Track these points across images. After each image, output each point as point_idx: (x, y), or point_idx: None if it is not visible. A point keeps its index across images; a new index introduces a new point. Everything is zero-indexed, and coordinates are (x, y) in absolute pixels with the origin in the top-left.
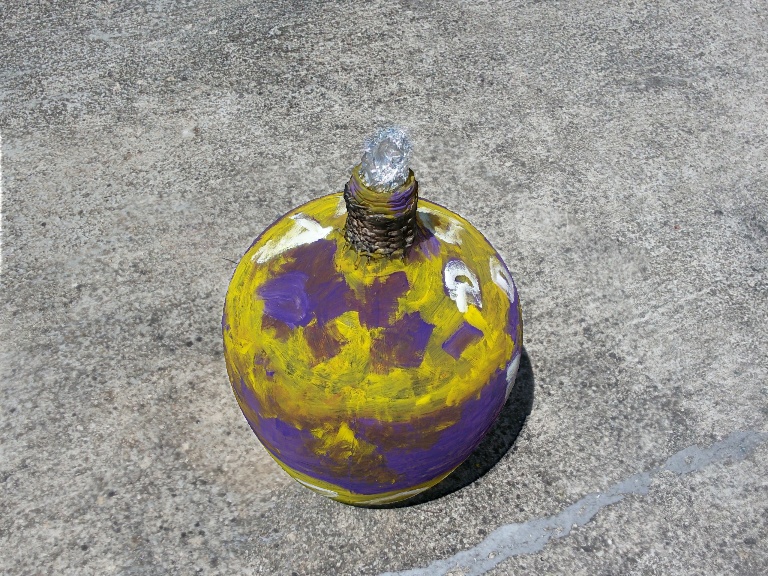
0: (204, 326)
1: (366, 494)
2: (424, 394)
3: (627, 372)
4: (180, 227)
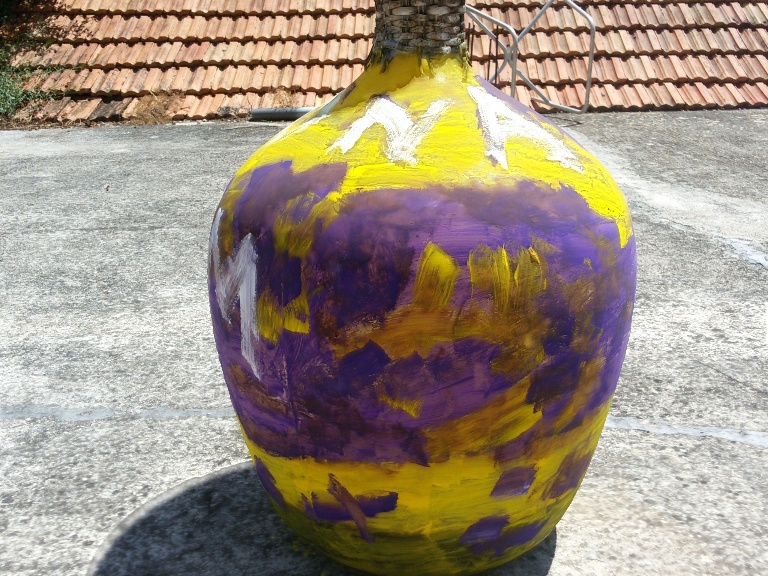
0: None
1: None
2: None
3: (21, 482)
4: None
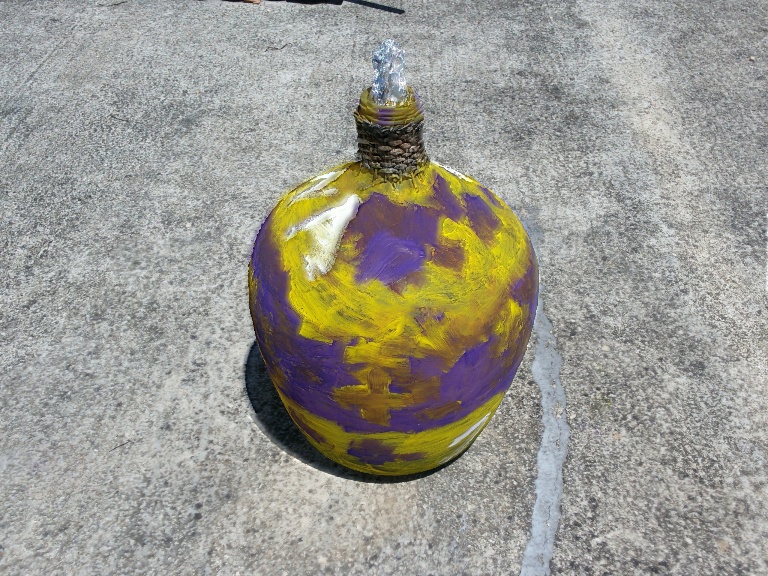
0: (185, 496)
1: (507, 389)
2: (520, 240)
3: None
4: (29, 474)
